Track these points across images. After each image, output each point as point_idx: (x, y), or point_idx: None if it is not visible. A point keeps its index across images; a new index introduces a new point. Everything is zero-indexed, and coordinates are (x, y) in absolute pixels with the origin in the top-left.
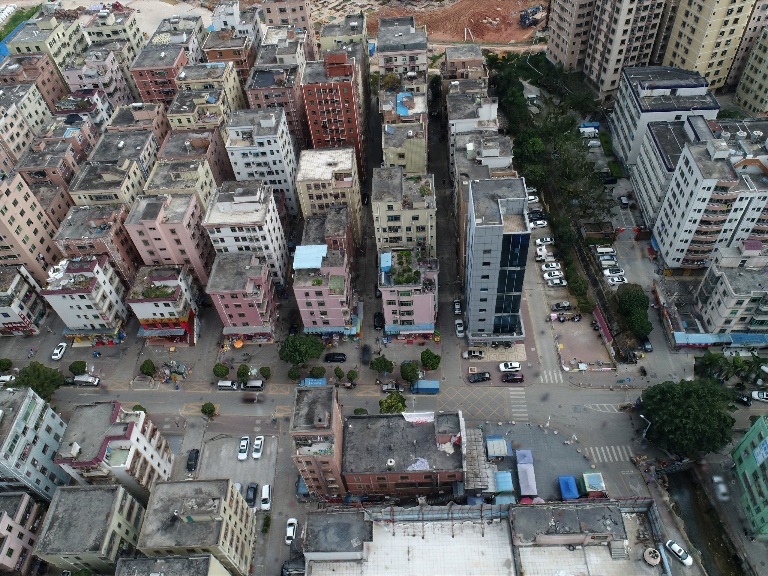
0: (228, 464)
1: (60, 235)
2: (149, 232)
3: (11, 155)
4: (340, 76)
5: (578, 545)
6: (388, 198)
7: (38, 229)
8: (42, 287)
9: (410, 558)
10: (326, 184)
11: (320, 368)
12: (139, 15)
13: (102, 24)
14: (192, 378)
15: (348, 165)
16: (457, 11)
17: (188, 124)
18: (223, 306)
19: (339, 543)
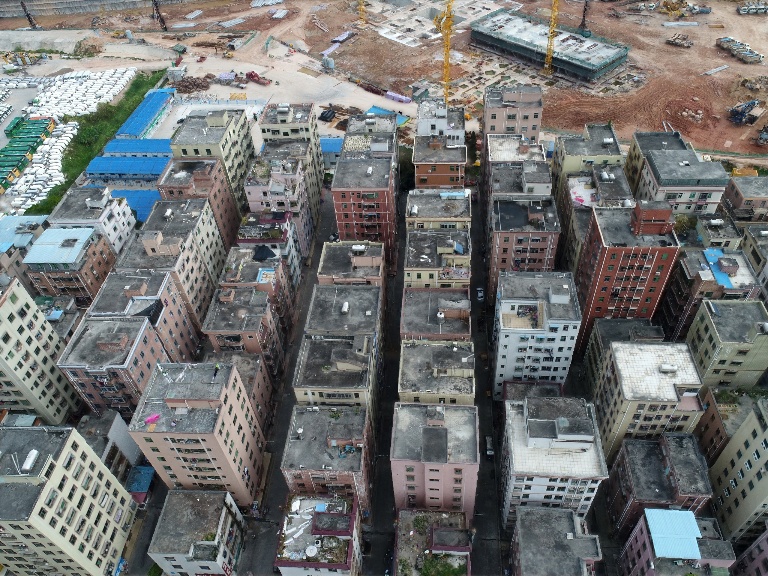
0: None
1: (287, 456)
2: (427, 473)
3: (184, 298)
4: (653, 235)
5: None
6: None
7: (245, 433)
8: (277, 553)
9: None
10: (668, 406)
11: None
12: (278, 88)
13: (281, 121)
14: None
15: (692, 375)
16: (645, 98)
17: (429, 280)
18: None
19: None
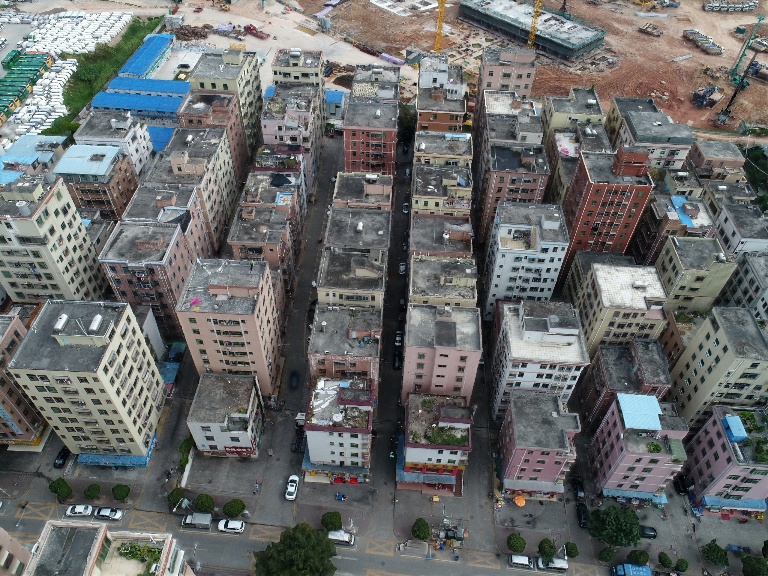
0: None
1: (312, 345)
2: (437, 358)
3: (204, 216)
4: (631, 176)
5: None
6: (753, 354)
7: (271, 328)
8: (307, 420)
9: None
10: (639, 314)
11: (645, 554)
12: (276, 42)
13: (293, 64)
14: (470, 544)
15: (659, 291)
16: (618, 79)
17: (434, 208)
18: (522, 460)
19: None
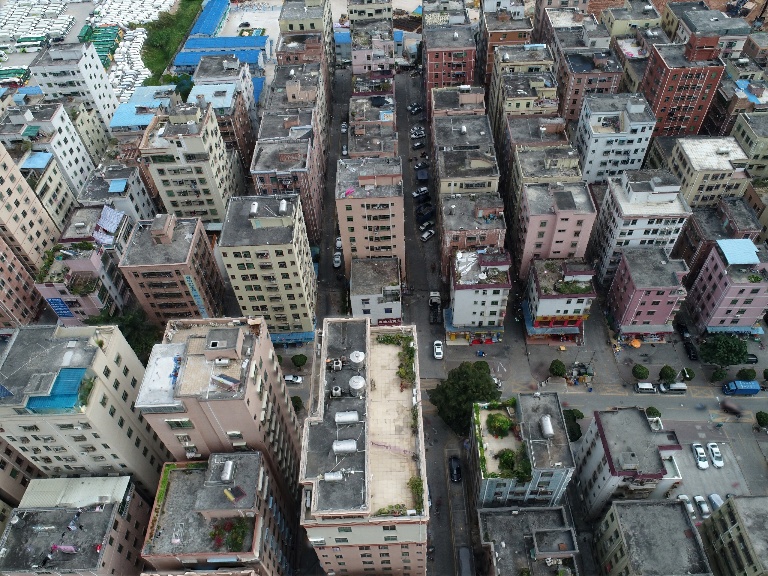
0: (689, 473)
1: (446, 225)
2: (558, 223)
3: None
4: (703, 60)
5: None
6: None
7: None
8: (456, 281)
9: None
10: (726, 174)
11: (752, 370)
12: None
13: (368, 2)
14: (599, 380)
15: (741, 155)
16: None
17: (525, 109)
18: (639, 303)
19: None
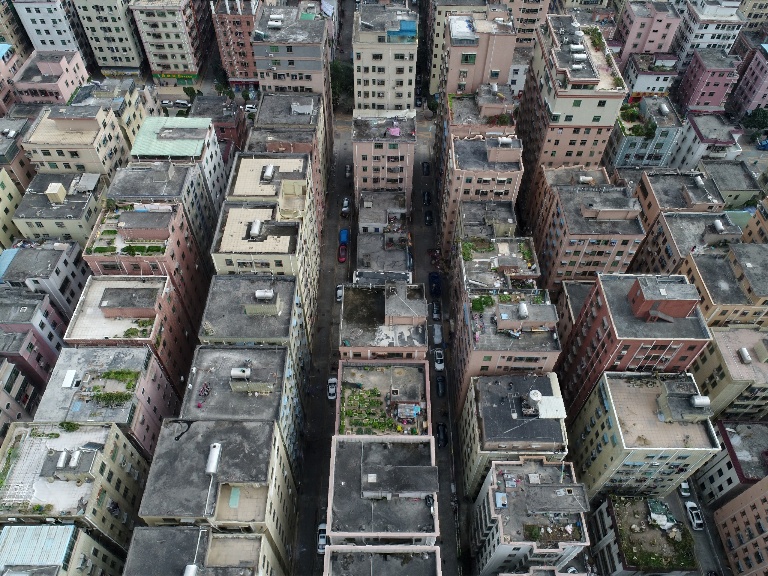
0: None
1: None
2: (654, 24)
3: None
4: None
5: None
6: None
7: None
8: None
9: None
10: None
11: None
12: None
13: None
14: None
15: None
16: None
17: None
18: (705, 84)
19: None
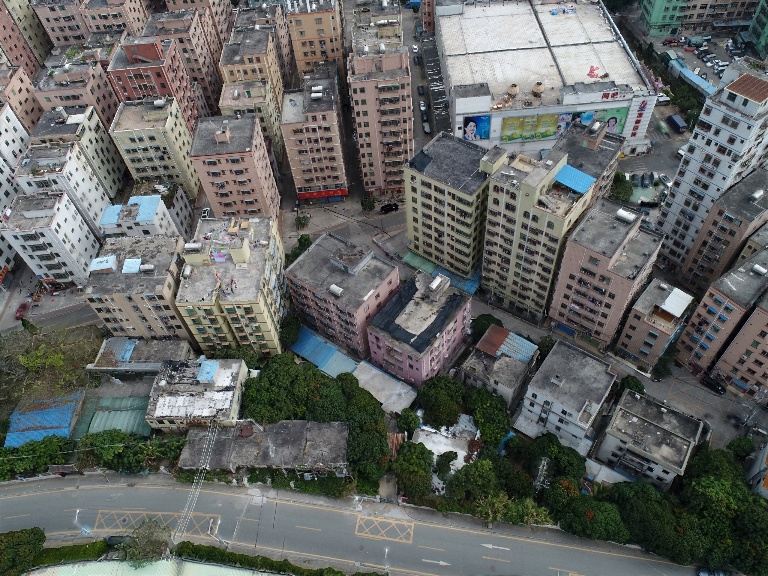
0: None
1: None
2: None
3: None
4: None
5: (561, 2)
6: None
7: None
8: None
9: (484, 11)
10: None
11: None
12: None
13: None
14: (343, 7)
15: None
16: None
17: None
18: None
19: (452, 3)
